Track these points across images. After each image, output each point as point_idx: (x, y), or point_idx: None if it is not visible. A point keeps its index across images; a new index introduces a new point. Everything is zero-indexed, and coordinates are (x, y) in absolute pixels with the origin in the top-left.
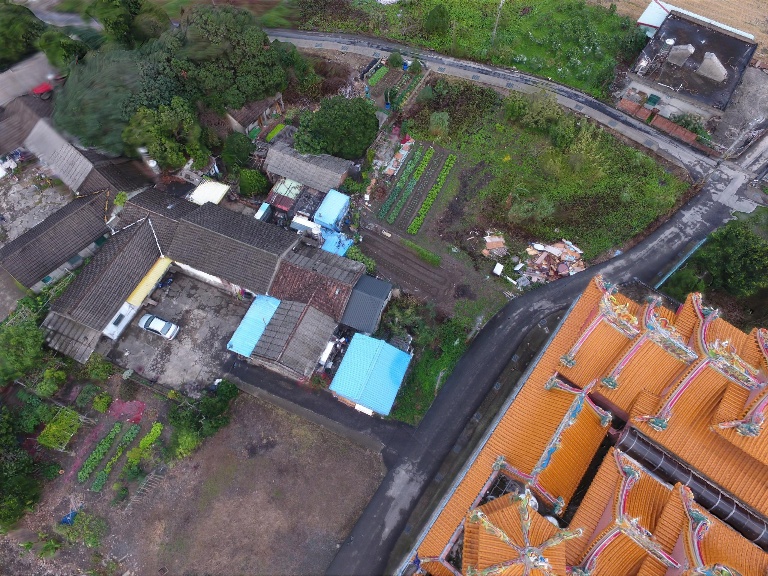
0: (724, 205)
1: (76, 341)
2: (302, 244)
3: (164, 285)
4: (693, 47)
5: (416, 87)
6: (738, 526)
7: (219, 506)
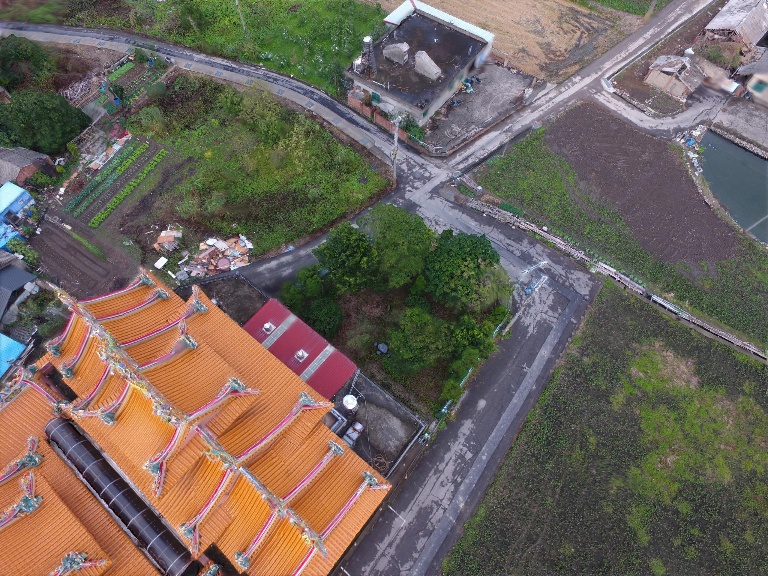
0: (414, 203)
1: None
2: None
3: None
4: (407, 45)
5: (154, 83)
6: (117, 514)
7: None
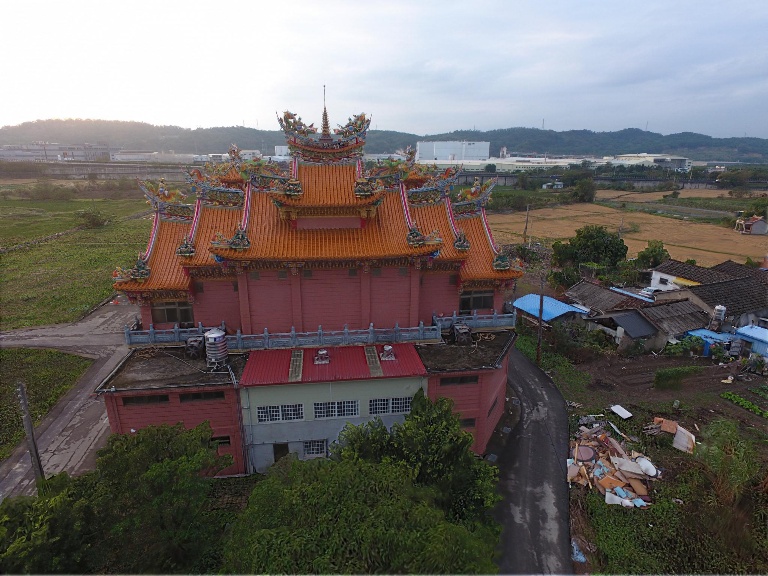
0: None
1: None
2: None
3: None
4: None
5: None
6: None
7: None
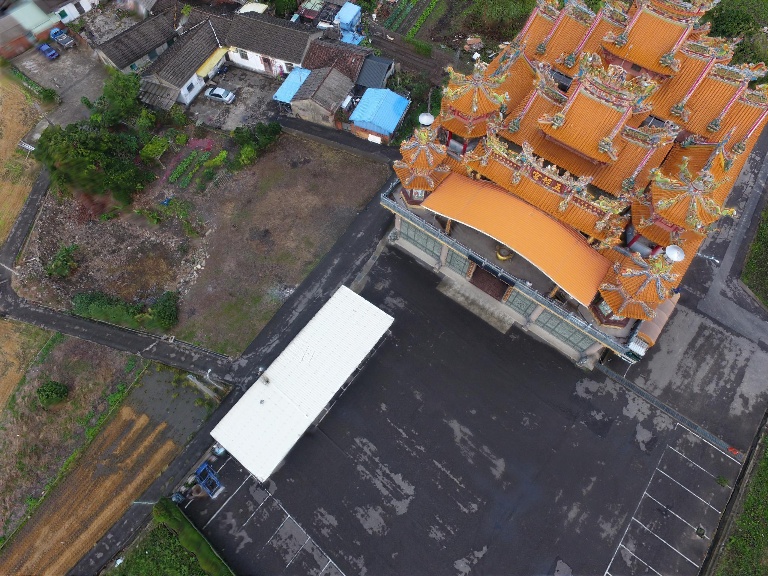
0: None
1: (161, 97)
2: (326, 37)
3: (221, 72)
4: None
5: None
6: None
7: None
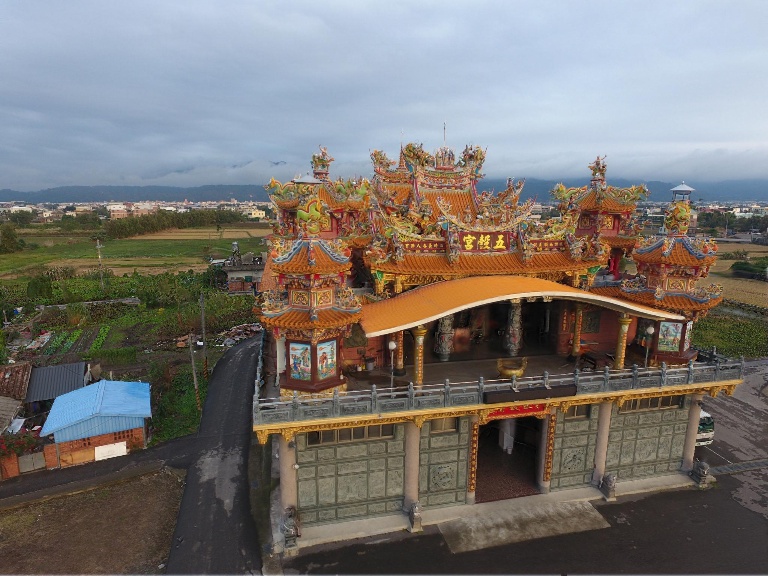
0: None
1: None
2: None
3: None
4: None
5: (36, 316)
6: None
7: None
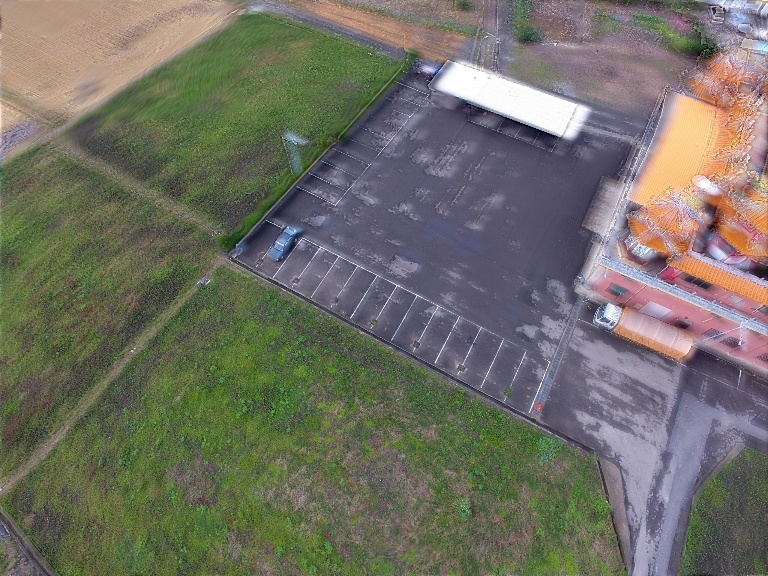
0: None
1: None
2: None
3: (742, 10)
4: None
5: None
6: None
7: (638, 66)
